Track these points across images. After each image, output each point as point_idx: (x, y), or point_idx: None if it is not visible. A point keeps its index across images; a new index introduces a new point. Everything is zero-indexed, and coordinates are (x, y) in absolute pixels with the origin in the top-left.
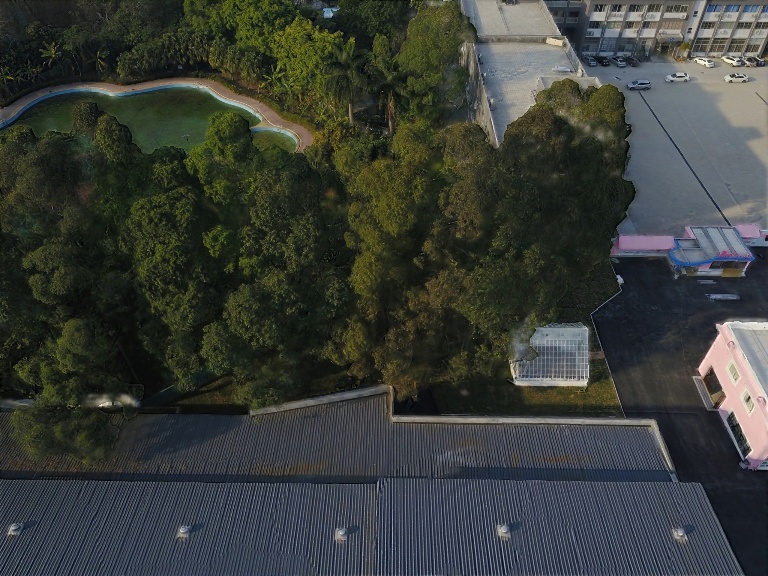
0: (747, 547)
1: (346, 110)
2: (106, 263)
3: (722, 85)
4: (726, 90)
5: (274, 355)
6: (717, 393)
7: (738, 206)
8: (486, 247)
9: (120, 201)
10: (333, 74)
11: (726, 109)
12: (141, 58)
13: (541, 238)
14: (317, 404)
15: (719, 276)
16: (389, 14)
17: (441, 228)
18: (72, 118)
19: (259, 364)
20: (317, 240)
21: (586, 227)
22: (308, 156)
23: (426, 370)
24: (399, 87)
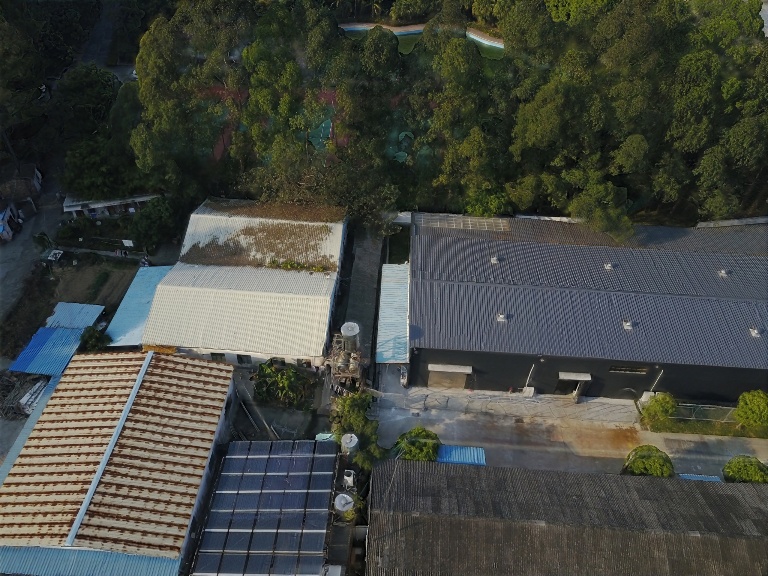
0: None
1: None
2: None
3: None
4: None
5: None
6: None
7: None
8: None
9: (665, 57)
10: None
11: None
12: (414, 4)
13: None
14: (738, 225)
15: None
16: None
17: None
18: None
19: None
20: None
21: None
22: None
23: None
24: None
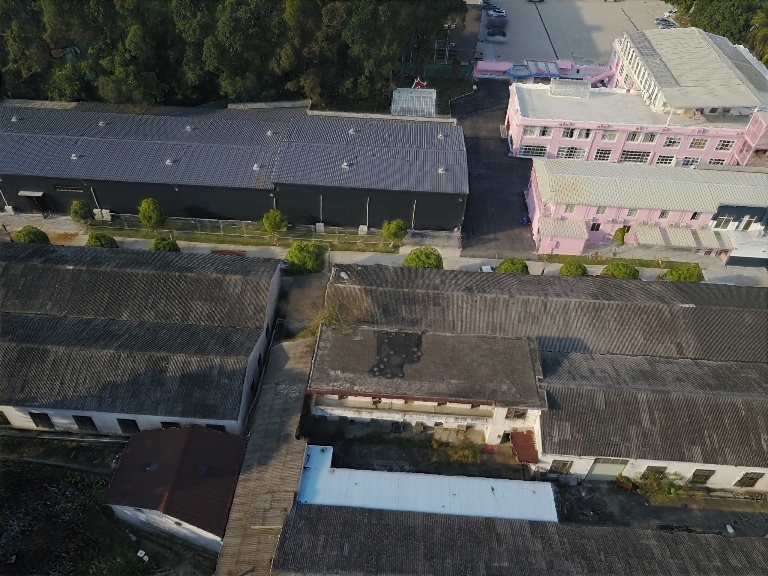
0: (496, 179)
1: None
2: (153, 2)
3: (598, 2)
4: (600, 5)
5: (243, 72)
6: None
7: (573, 62)
8: (358, 2)
9: None
10: None
11: (594, 15)
12: None
13: (391, 3)
14: (267, 107)
15: None
16: None
17: None
18: None
19: (234, 75)
20: None
21: (422, 8)
22: None
23: None
24: None
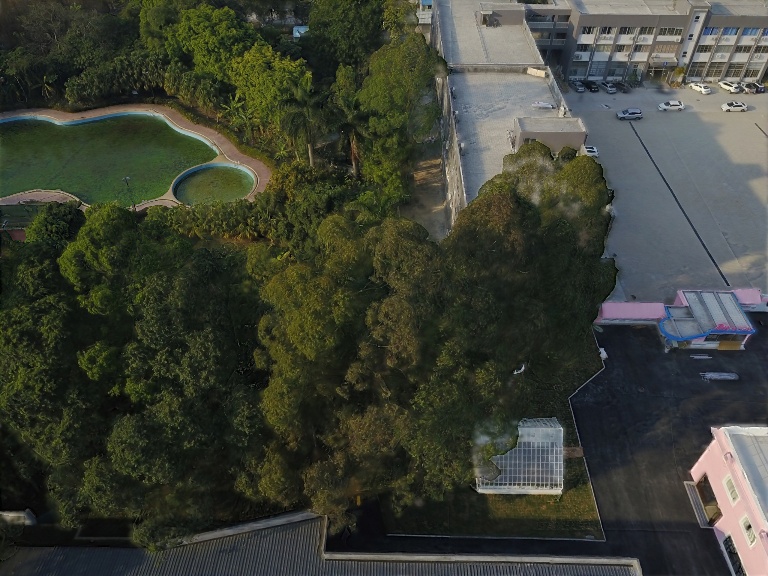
0: None
1: (305, 149)
2: None
3: (719, 115)
4: (723, 120)
5: None
6: (712, 507)
7: (736, 260)
8: (429, 366)
9: None
10: (289, 111)
11: (723, 143)
12: (91, 84)
13: (498, 351)
14: (237, 533)
15: (715, 349)
16: (359, 37)
17: (370, 351)
18: (12, 150)
19: (162, 493)
20: (219, 360)
21: (556, 328)
22: (258, 204)
23: (376, 472)
24: (361, 127)
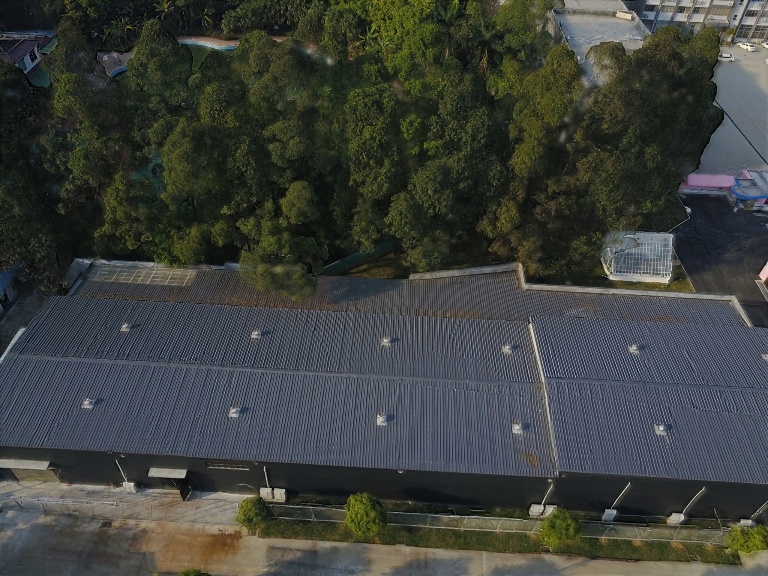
0: None
1: None
2: (318, 142)
3: (763, 66)
4: (767, 70)
5: (433, 230)
6: None
7: None
8: (618, 143)
9: (337, 92)
10: None
11: None
12: (245, 16)
13: (658, 140)
14: (461, 275)
15: None
16: None
17: (590, 121)
18: None
19: (422, 236)
20: (489, 129)
21: None
22: None
23: None
24: (495, 44)
